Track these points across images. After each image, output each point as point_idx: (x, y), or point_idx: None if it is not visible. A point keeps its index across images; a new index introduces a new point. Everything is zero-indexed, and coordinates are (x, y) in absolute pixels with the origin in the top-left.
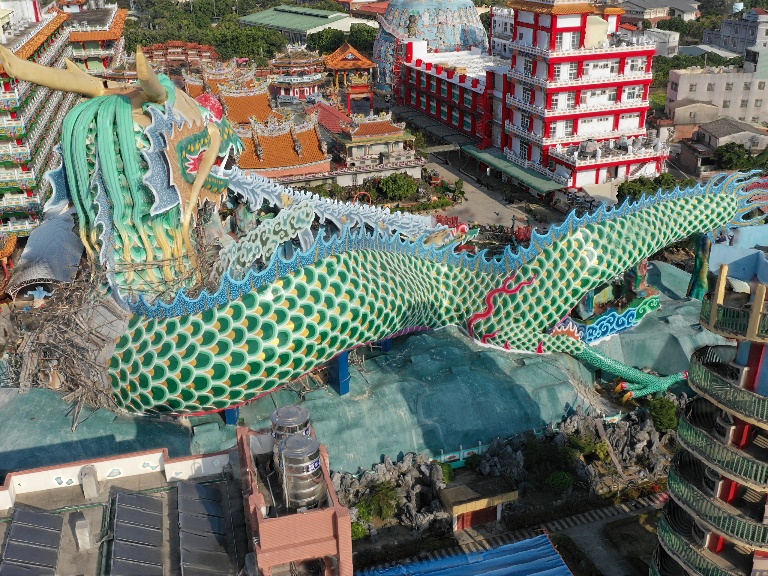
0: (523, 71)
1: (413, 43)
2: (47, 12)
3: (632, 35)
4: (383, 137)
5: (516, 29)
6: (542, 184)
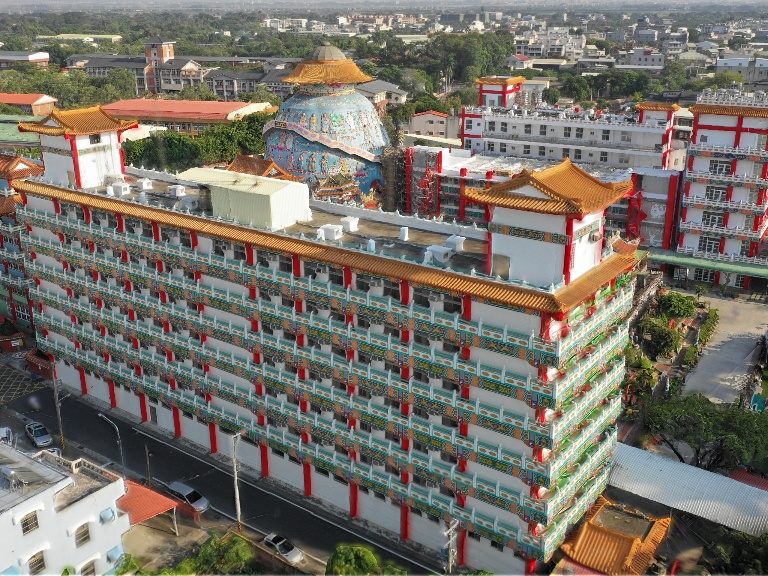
0: (708, 171)
1: (442, 152)
2: (15, 161)
3: (447, 121)
4: None
5: (697, 132)
6: None
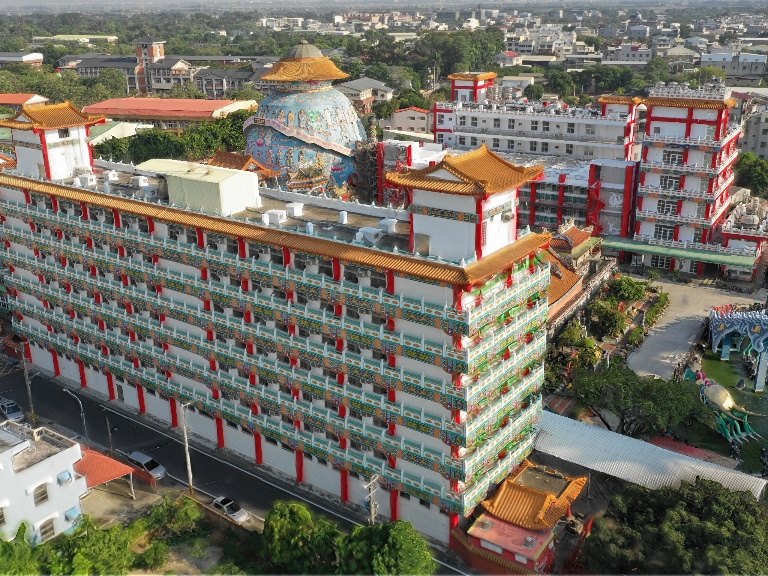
0: None
1: (411, 145)
2: None
3: (428, 117)
4: (583, 244)
5: (650, 124)
6: (735, 259)
